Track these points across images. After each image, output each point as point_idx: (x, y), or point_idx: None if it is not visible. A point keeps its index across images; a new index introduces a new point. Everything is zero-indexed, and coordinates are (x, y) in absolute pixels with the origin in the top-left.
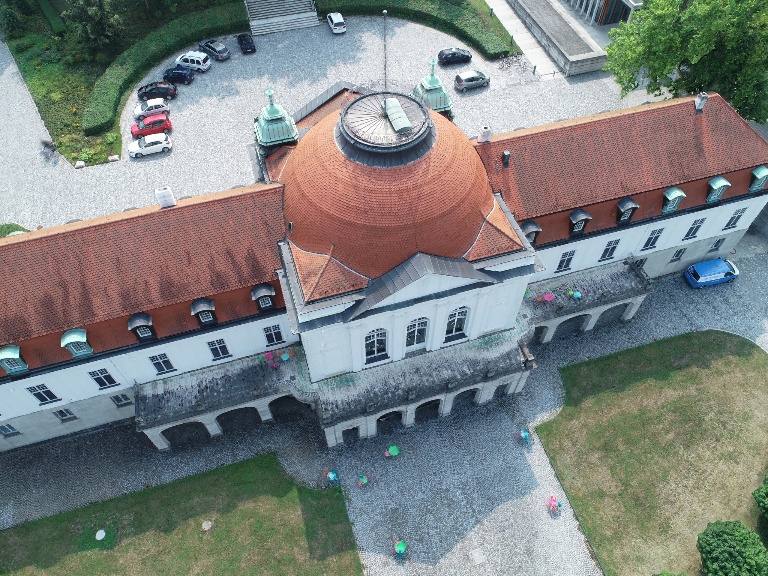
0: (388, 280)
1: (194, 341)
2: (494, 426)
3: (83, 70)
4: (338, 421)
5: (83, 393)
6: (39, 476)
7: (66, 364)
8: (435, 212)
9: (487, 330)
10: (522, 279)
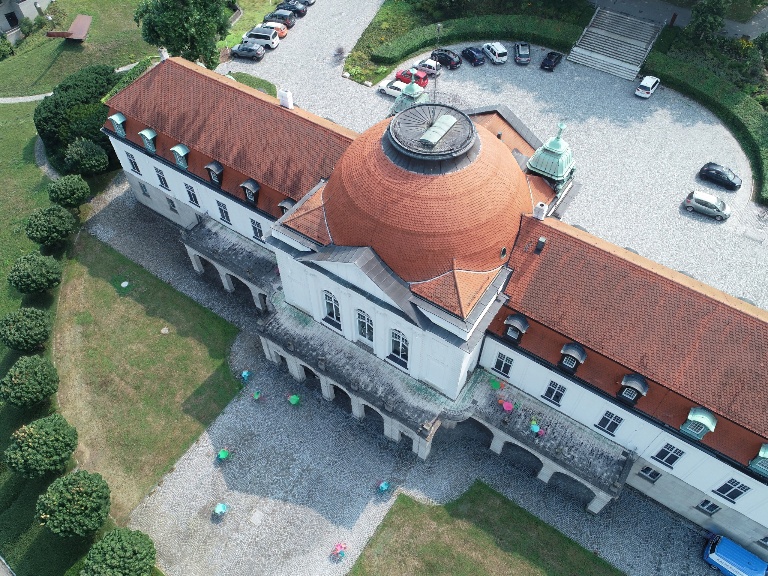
0: (337, 250)
1: (243, 210)
2: (376, 460)
3: (419, 17)
4: (266, 336)
5: (181, 196)
6: (140, 230)
7: (172, 165)
8: (401, 224)
9: (428, 380)
10: (455, 349)
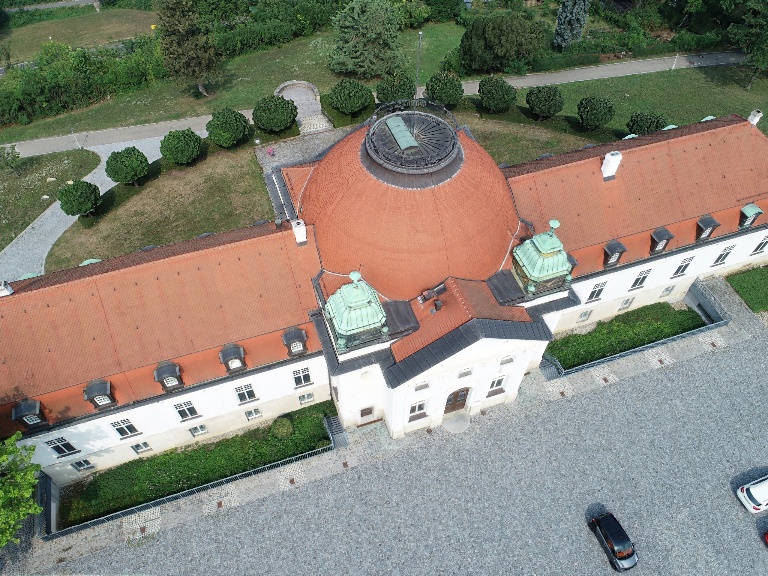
0: None
1: None
2: None
3: None
4: None
5: None
6: None
7: None
8: None
9: None
10: None
